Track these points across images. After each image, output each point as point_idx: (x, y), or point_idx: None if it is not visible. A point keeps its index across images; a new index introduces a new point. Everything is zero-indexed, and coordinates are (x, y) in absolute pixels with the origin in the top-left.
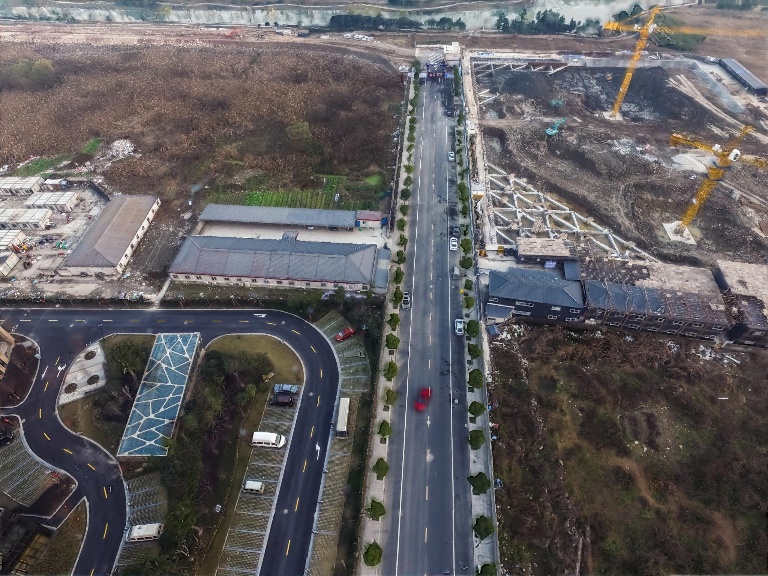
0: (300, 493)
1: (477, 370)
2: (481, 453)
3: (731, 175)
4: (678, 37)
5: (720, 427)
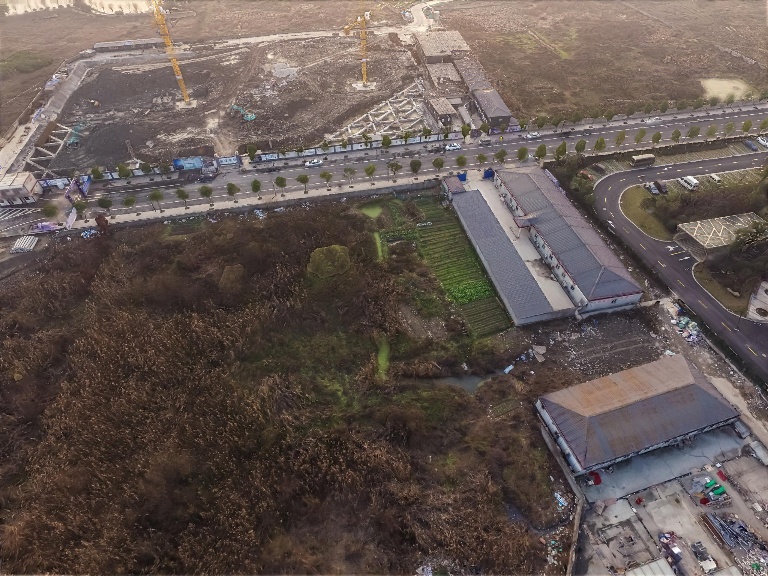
0: (694, 168)
1: (576, 112)
2: (606, 123)
3: (298, 63)
4: (20, 60)
5: (526, 75)
